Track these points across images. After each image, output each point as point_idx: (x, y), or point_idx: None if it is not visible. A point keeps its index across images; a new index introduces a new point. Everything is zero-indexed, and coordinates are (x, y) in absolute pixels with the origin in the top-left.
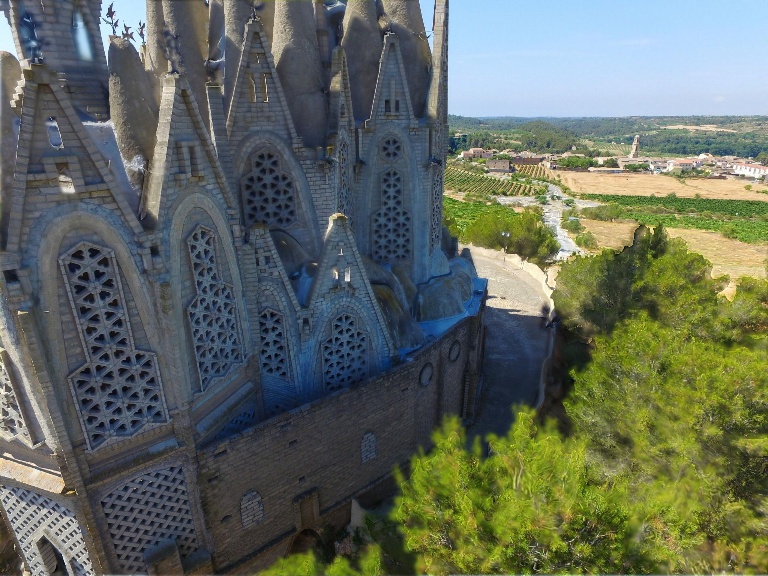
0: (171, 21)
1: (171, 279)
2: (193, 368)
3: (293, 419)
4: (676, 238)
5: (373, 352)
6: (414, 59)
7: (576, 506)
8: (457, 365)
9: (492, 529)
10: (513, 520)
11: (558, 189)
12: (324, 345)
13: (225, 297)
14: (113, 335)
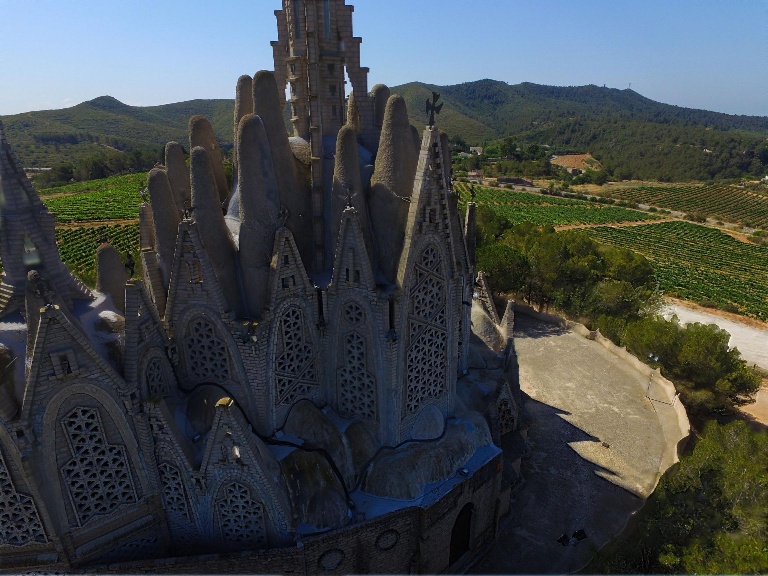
0: (151, 209)
1: (44, 448)
2: (71, 509)
3: (157, 568)
4: None
5: (270, 521)
6: (394, 223)
7: None
8: (396, 552)
9: None
10: None
11: None
12: (220, 502)
13: (114, 454)
14: (3, 479)
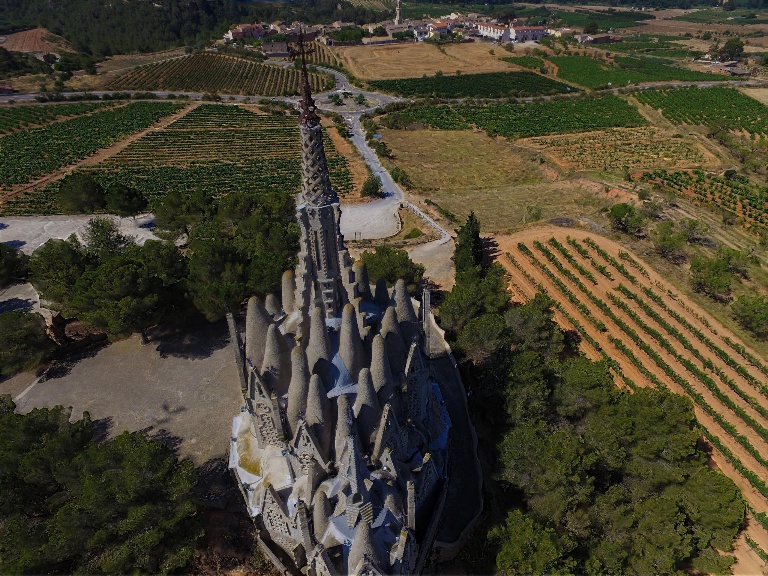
0: None
1: None
2: None
3: None
4: (496, 262)
5: (432, 483)
6: (415, 334)
7: (555, 557)
8: None
9: (535, 568)
10: (543, 567)
11: (344, 79)
12: None
13: None
14: None
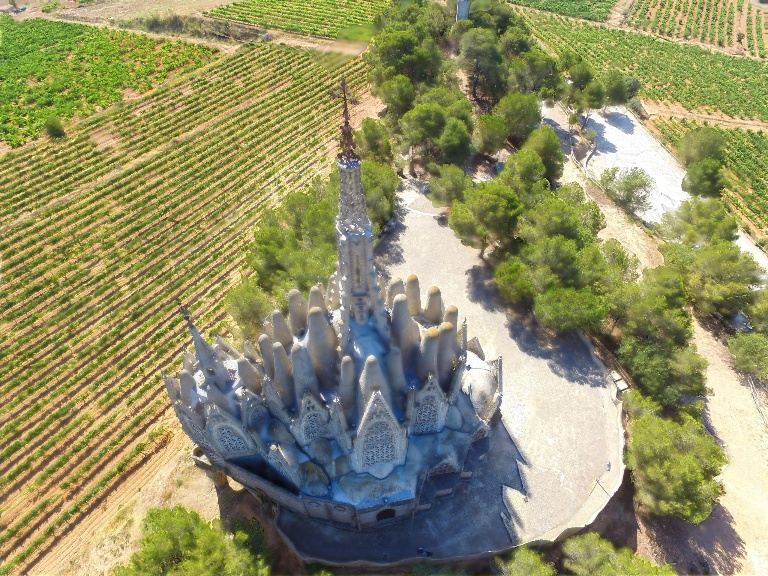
0: None
1: (213, 435)
2: None
3: None
4: None
5: None
6: None
7: None
8: (345, 512)
9: None
10: None
11: None
12: None
13: None
14: None
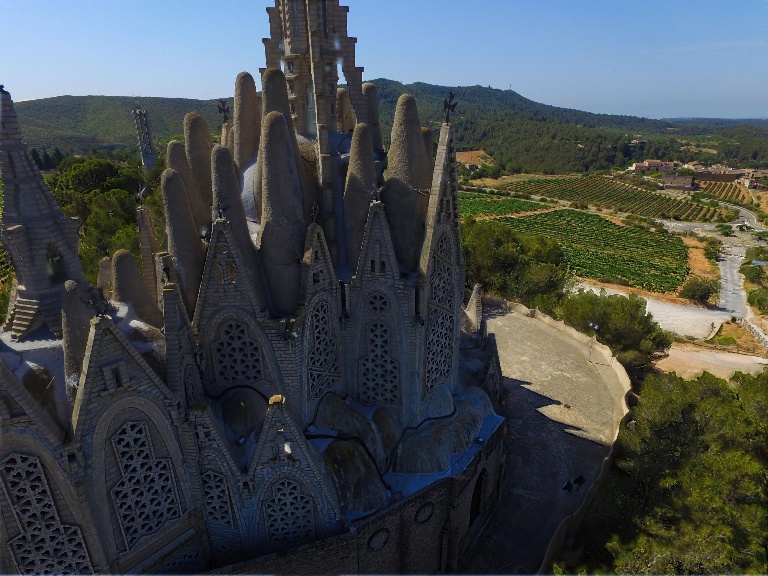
0: (166, 211)
1: (94, 471)
2: (119, 533)
3: None
4: None
5: (319, 513)
6: (412, 214)
7: None
8: (431, 523)
9: None
10: None
11: (753, 216)
12: (267, 503)
13: (160, 469)
14: (45, 512)
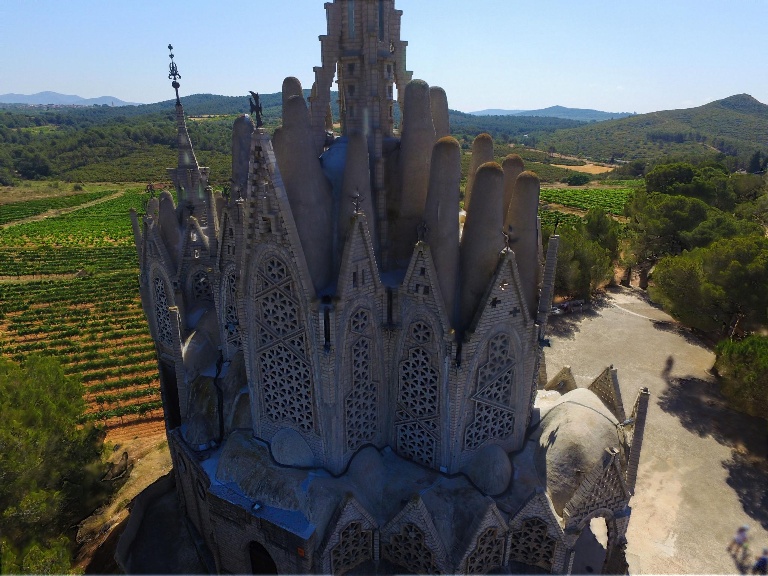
0: None
1: None
2: None
3: None
4: None
5: None
6: None
7: None
8: None
9: None
10: None
11: None
12: None
13: None
14: None
